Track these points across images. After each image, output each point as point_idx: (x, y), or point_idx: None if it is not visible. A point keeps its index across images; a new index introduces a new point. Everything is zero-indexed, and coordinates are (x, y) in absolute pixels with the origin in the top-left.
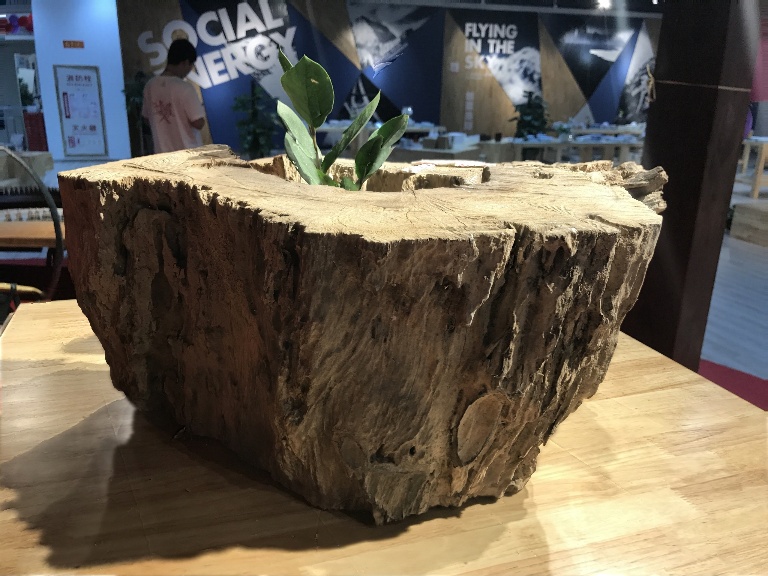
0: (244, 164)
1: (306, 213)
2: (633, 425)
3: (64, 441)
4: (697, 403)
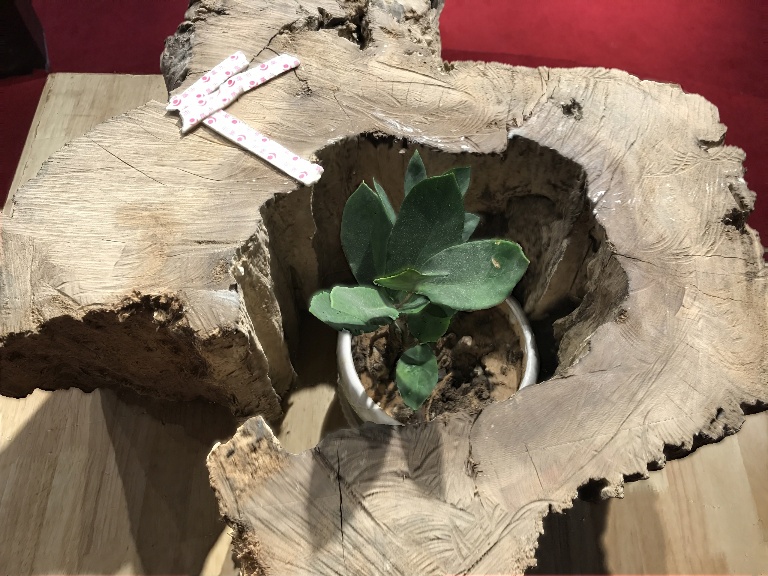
0: (476, 417)
1: (715, 389)
2: None
3: None
4: None
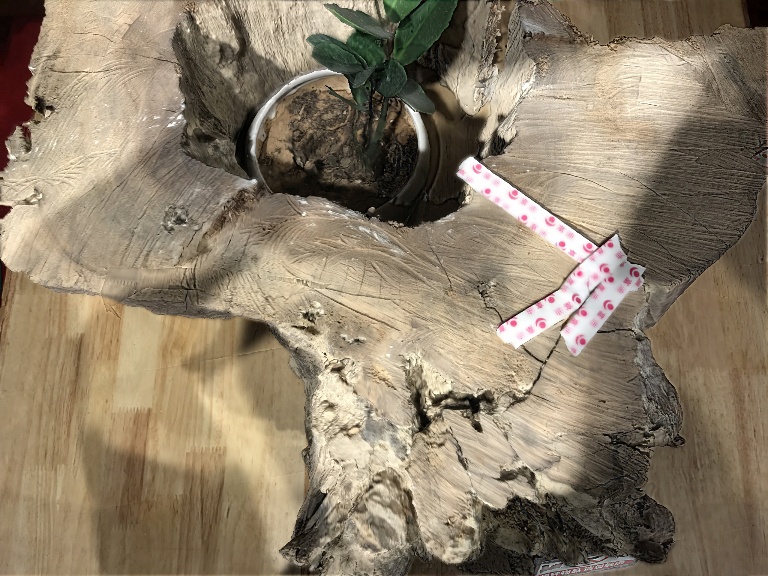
0: None
1: None
2: (248, 453)
3: None
4: (261, 567)
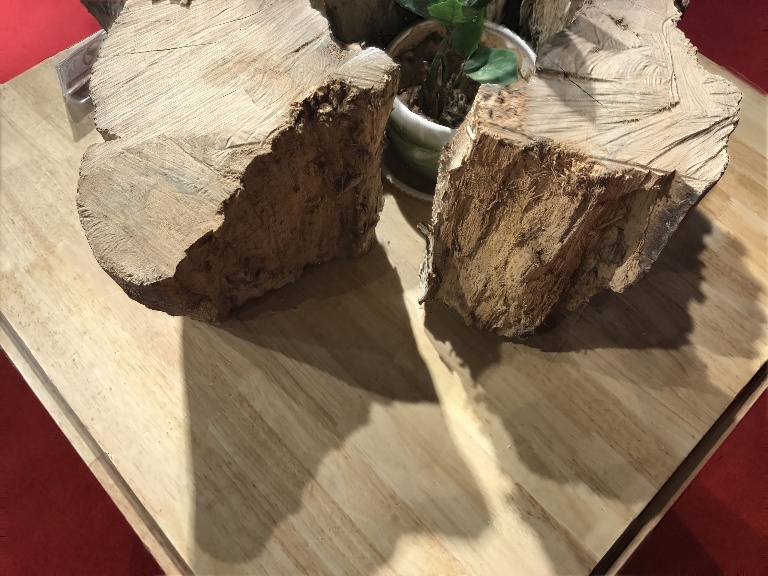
0: None
1: None
2: None
3: (623, 335)
4: None
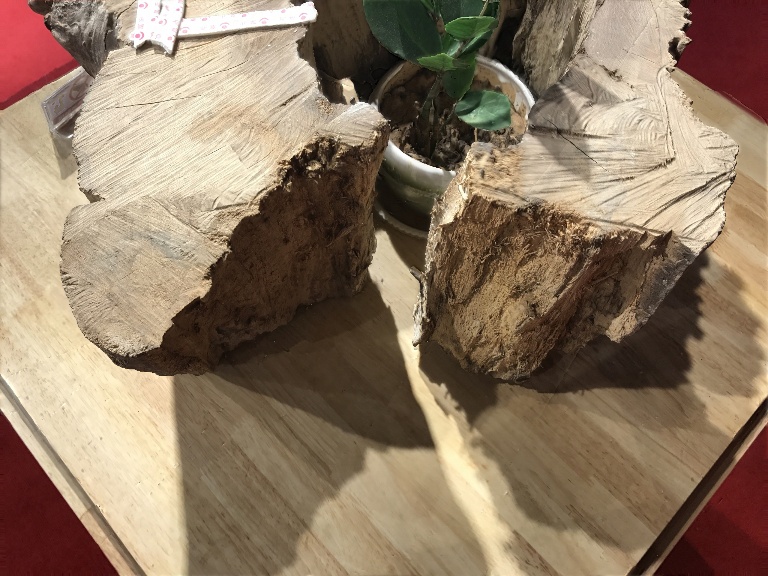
0: None
1: None
2: None
3: (620, 374)
4: None
